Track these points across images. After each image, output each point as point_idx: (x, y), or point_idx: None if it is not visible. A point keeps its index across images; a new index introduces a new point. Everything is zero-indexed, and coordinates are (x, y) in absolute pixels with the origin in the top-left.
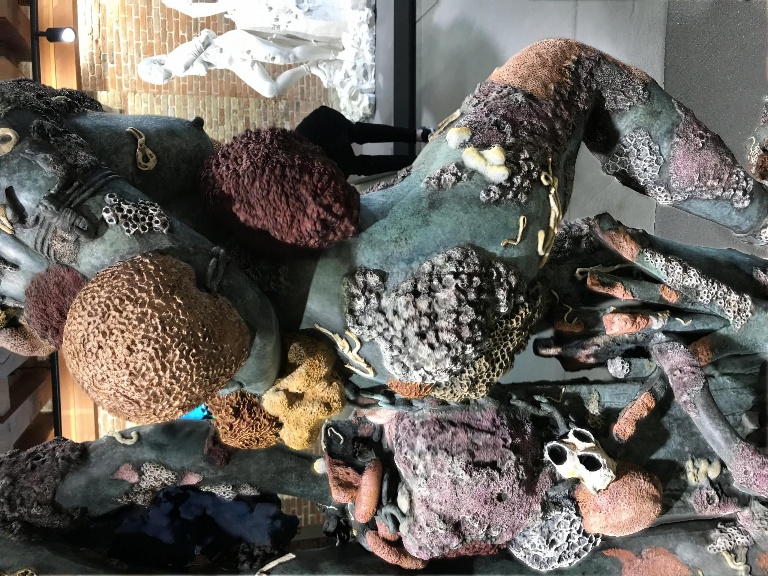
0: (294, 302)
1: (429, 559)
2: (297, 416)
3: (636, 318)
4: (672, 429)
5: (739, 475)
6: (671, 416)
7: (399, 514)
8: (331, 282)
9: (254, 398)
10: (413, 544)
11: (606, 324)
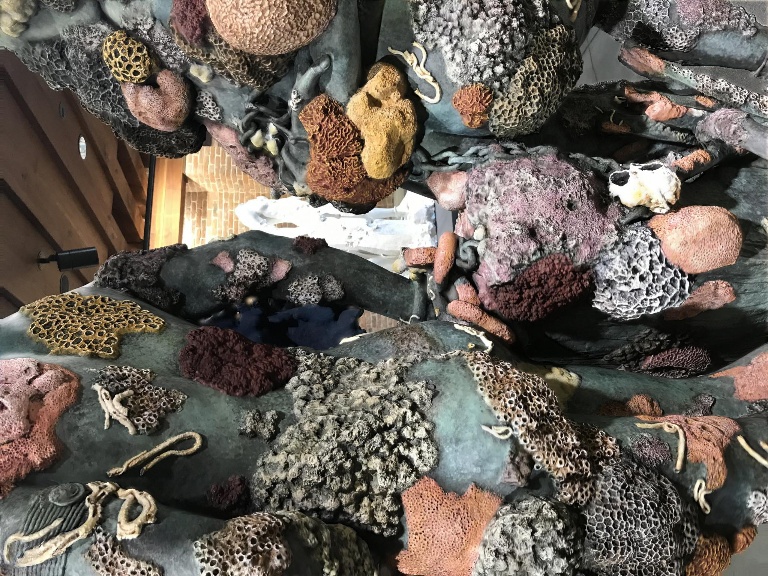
0: (371, 27)
1: (515, 340)
2: (376, 122)
3: (675, 105)
4: (739, 199)
5: None
6: (735, 190)
7: (476, 242)
8: (399, 4)
9: (340, 107)
10: (492, 258)
11: (648, 112)
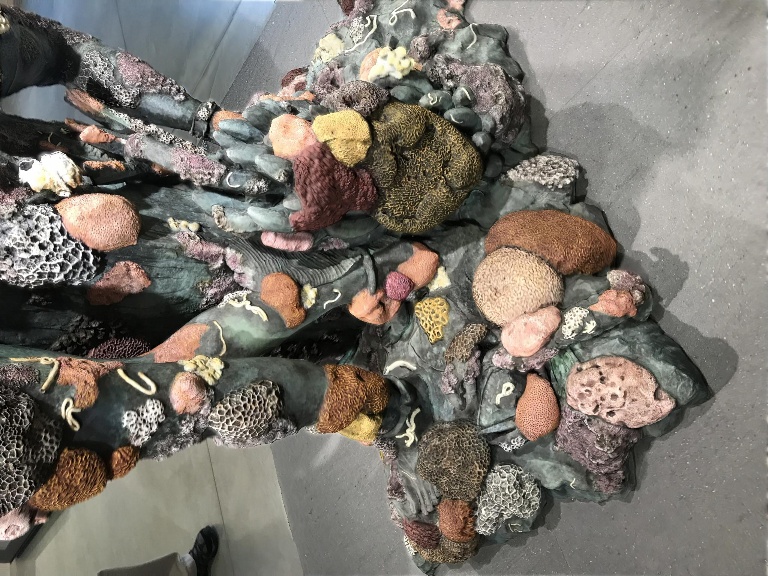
0: None
1: None
2: None
3: None
4: (154, 205)
5: (179, 165)
6: (152, 199)
7: None
8: None
9: None
10: None
11: None
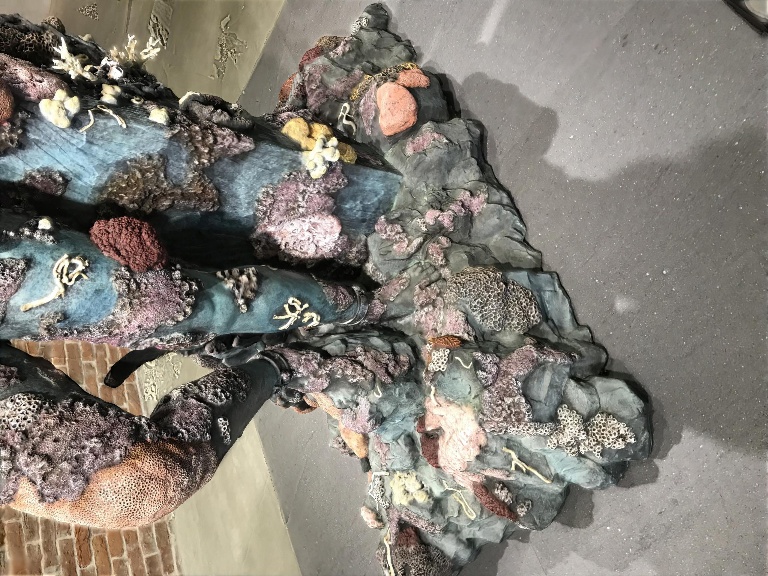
0: None
1: None
2: None
3: None
4: None
5: None
6: None
7: None
8: None
9: None
10: None
11: None
